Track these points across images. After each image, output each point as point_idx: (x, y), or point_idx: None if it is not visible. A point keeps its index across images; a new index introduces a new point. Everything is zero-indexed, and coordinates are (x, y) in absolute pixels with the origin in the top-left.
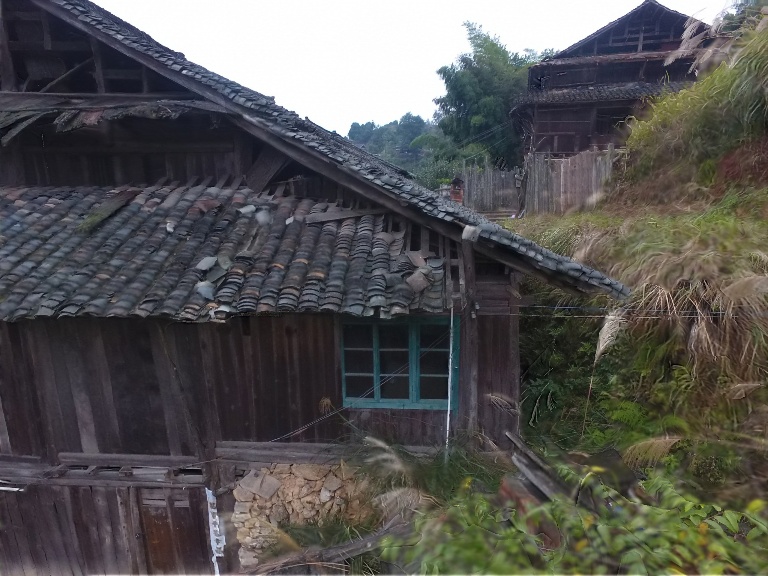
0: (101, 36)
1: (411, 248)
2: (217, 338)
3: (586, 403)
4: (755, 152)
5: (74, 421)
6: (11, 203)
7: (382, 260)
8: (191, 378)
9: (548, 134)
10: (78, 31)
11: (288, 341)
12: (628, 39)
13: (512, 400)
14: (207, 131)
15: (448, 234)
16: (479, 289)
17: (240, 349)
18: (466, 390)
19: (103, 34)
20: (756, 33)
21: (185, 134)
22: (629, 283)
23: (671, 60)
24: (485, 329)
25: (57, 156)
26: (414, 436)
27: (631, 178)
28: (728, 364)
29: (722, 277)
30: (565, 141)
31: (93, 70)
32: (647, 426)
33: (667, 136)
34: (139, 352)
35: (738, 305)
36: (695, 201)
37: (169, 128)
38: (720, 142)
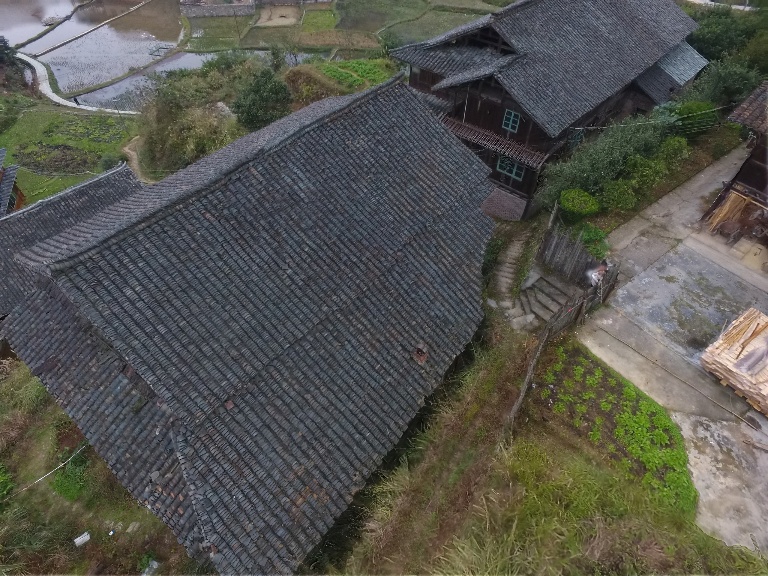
0: None
1: None
2: None
3: None
4: None
5: None
6: None
7: None
8: None
9: (767, 168)
10: None
11: None
12: None
13: None
14: None
15: None
16: None
17: None
18: None
19: None
20: None
21: None
22: None
23: None
24: None
25: None
26: None
27: None
28: None
29: None
30: None
31: None
32: None
33: None
34: None
35: None
36: None
37: None
38: None
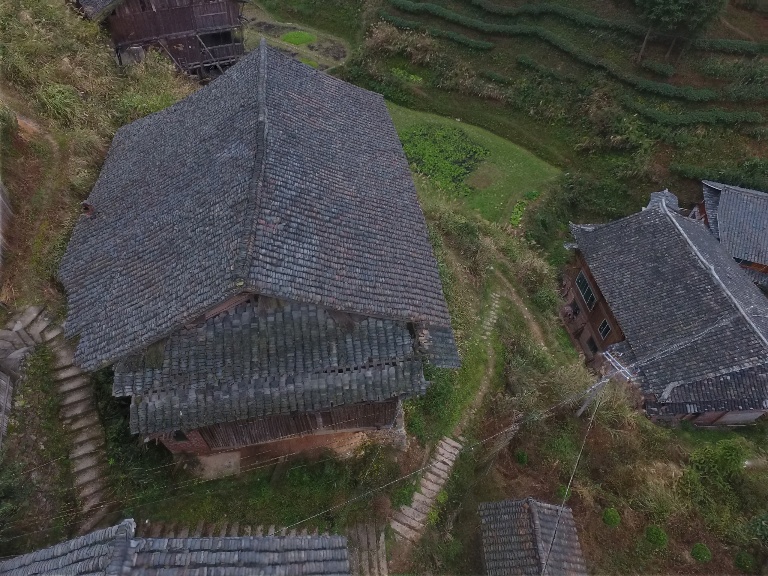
0: None
1: None
2: None
3: None
4: None
5: None
6: None
7: None
8: None
9: None
10: None
11: None
12: None
13: None
14: None
15: None
16: None
17: None
18: None
19: None
20: None
21: None
22: None
23: None
24: None
25: None
26: None
27: (5, 182)
28: None
29: None
30: None
31: None
32: None
33: None
34: None
35: None
36: None
37: None
38: None
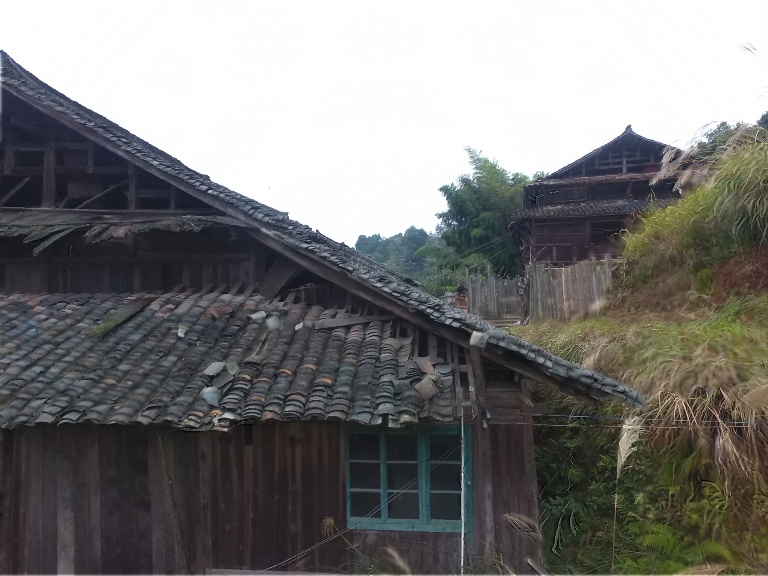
0: (139, 162)
1: (419, 354)
2: (217, 448)
3: (613, 526)
4: (748, 262)
5: (54, 543)
6: (30, 309)
7: (390, 366)
8: (186, 493)
9: (546, 245)
10: (119, 158)
11: (291, 452)
12: (613, 163)
13: (531, 521)
14: (225, 243)
15: (456, 340)
16: (489, 396)
17: (240, 460)
18: (481, 509)
19: (141, 160)
20: (729, 158)
21: (204, 245)
22: (643, 391)
23: (655, 180)
24: (498, 440)
25: (82, 265)
26: (425, 564)
27: (631, 286)
28: (762, 480)
29: (738, 385)
30: (563, 251)
31: (127, 190)
32: (684, 554)
33: (661, 247)
34: (134, 463)
35: (760, 415)
36: (698, 308)
37: (190, 240)
38: (713, 253)
